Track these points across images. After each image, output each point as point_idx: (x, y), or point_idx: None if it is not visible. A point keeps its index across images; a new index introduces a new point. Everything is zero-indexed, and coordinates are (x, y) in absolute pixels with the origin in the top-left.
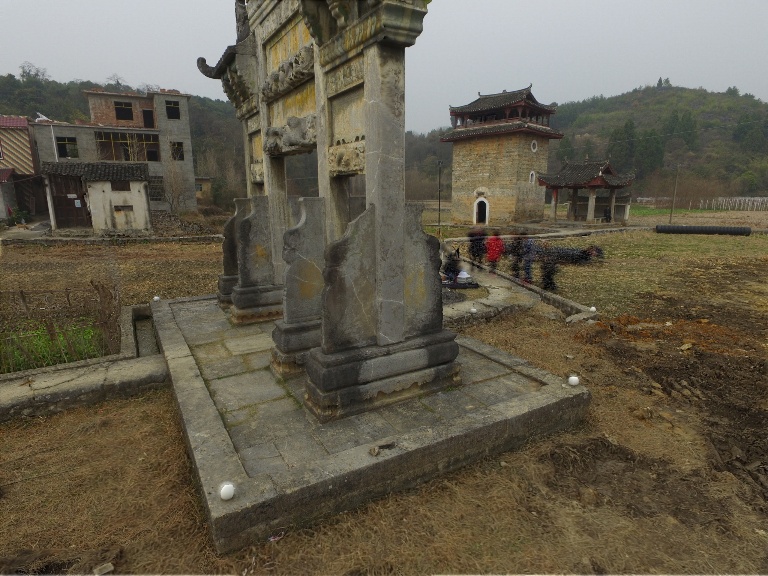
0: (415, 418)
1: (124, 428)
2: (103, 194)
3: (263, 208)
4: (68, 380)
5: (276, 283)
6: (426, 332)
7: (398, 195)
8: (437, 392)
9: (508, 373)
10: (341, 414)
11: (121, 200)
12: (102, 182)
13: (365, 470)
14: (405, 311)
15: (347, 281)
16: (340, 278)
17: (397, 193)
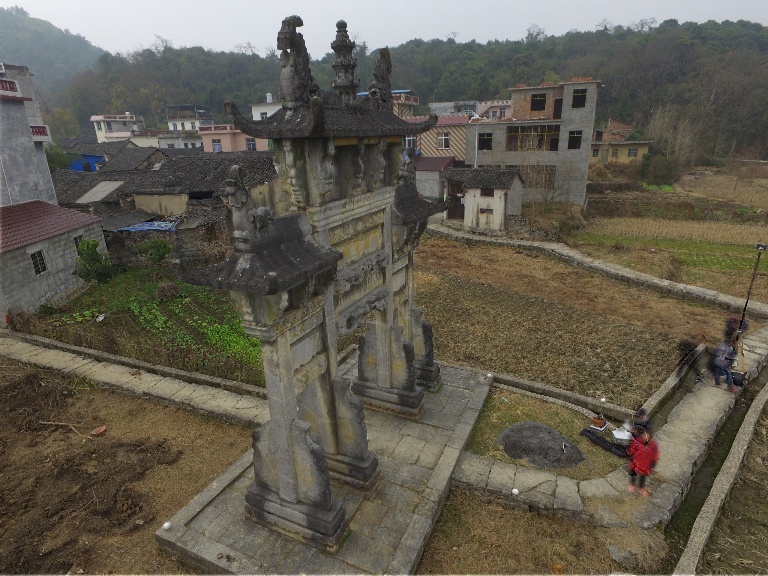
0: (273, 554)
1: (233, 452)
2: (474, 198)
3: (374, 332)
4: (248, 407)
5: (378, 385)
6: (317, 505)
7: (281, 420)
8: (314, 548)
9: (375, 575)
10: (254, 520)
11: (486, 204)
12: (475, 189)
13: (207, 561)
14: (300, 485)
15: (262, 453)
16: (258, 449)
17: (280, 418)
